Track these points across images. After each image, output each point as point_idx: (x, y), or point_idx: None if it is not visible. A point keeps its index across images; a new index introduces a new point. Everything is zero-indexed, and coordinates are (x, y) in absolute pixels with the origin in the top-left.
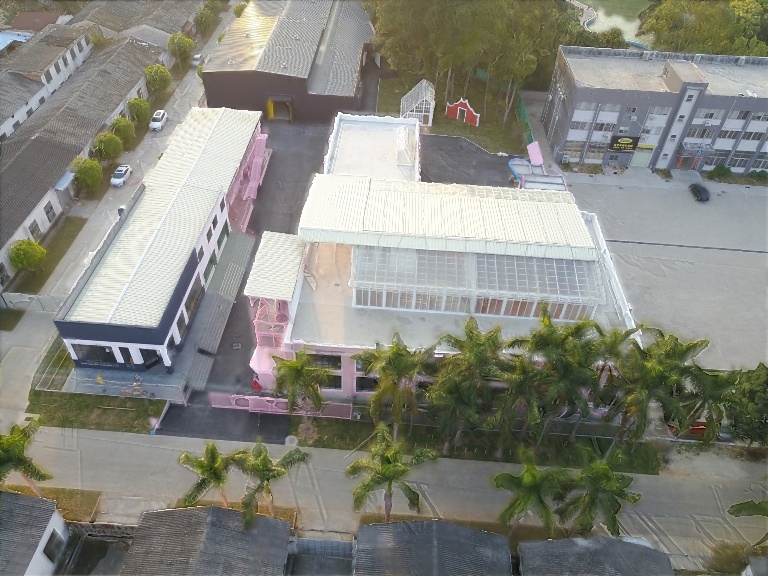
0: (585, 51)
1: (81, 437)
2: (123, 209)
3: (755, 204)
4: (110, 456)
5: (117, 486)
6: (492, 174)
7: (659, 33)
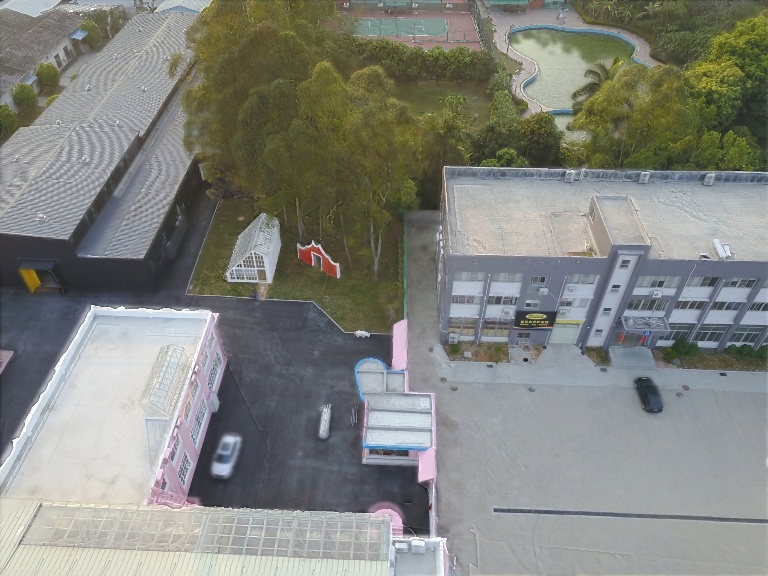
0: (481, 172)
1: None
2: None
3: (734, 411)
4: None
5: None
6: (338, 376)
7: (592, 134)
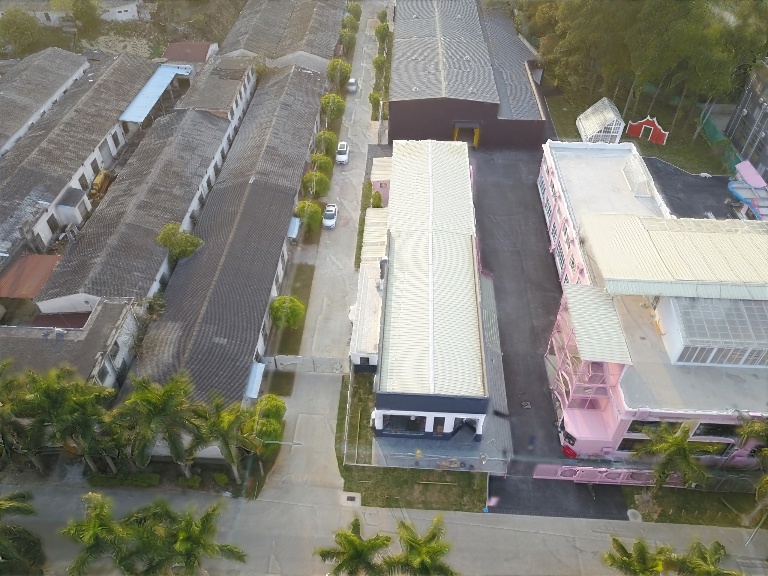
0: None
1: (414, 518)
2: (387, 260)
3: None
4: (454, 540)
5: (476, 575)
6: (704, 198)
7: None
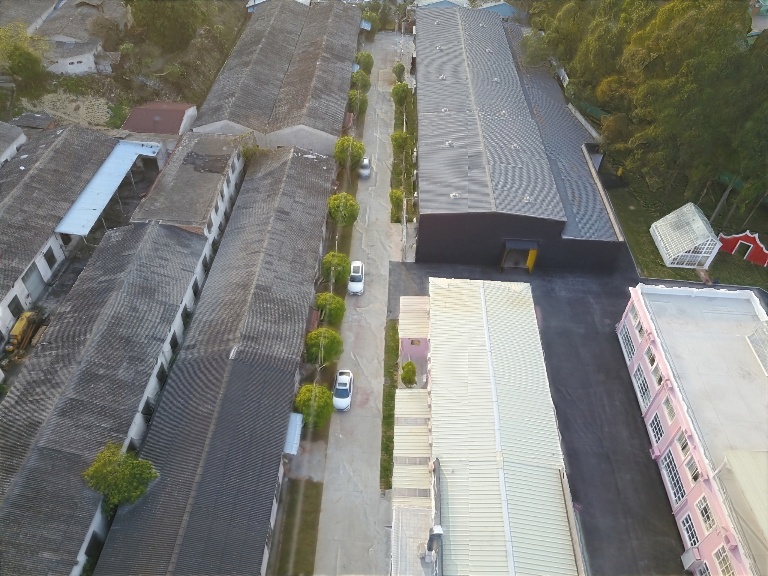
0: None
1: None
2: (441, 534)
3: None
4: None
5: None
6: None
7: None
